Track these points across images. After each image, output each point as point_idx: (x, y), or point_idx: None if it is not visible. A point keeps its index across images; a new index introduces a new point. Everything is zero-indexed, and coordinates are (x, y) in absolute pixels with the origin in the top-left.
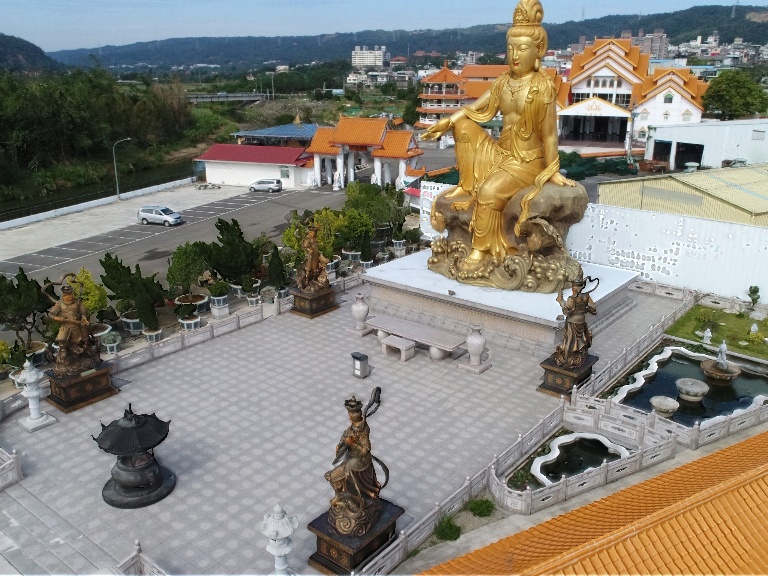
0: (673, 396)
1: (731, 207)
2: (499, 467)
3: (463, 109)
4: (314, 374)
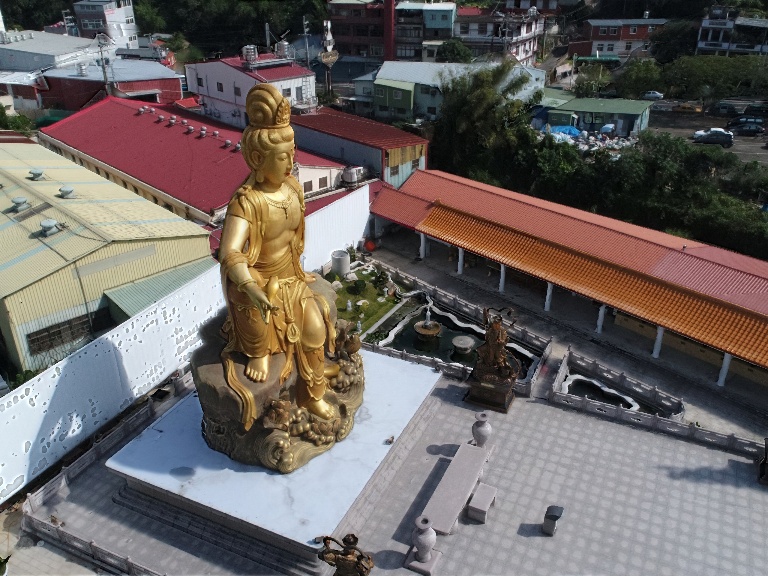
0: (448, 361)
1: (186, 239)
2: (650, 422)
3: (245, 259)
4: (570, 573)
